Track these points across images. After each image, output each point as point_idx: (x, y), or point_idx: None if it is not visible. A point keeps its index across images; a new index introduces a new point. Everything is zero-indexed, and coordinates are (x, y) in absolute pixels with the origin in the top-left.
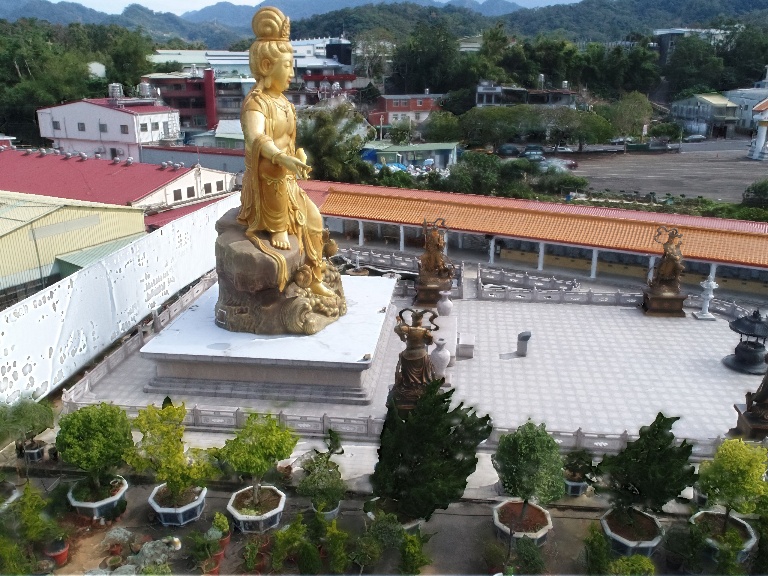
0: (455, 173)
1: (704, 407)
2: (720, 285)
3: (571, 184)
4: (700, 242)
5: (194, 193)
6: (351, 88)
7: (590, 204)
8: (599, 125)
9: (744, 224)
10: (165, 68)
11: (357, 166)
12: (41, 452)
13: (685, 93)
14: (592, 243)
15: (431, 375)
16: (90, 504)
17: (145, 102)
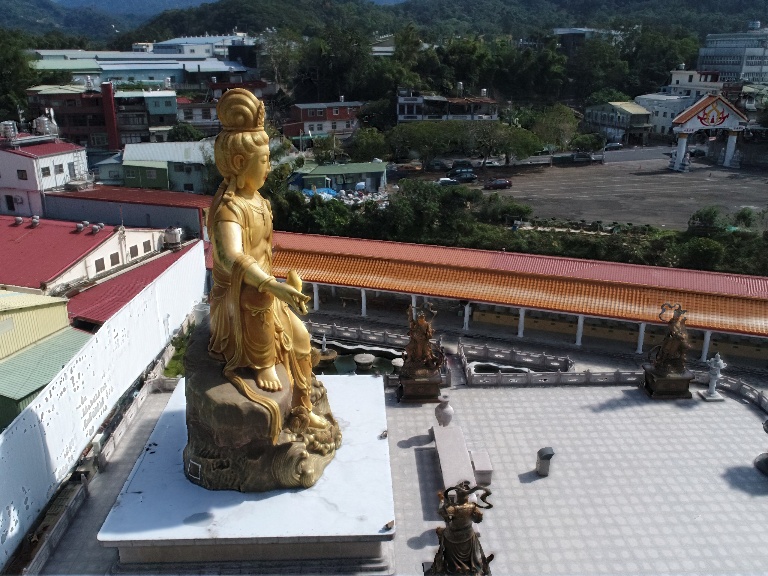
0: (395, 204)
1: (764, 541)
2: (711, 349)
3: (515, 212)
4: (692, 307)
5: (118, 259)
6: (261, 96)
7: (537, 234)
8: (528, 141)
9: (725, 278)
10: (53, 77)
11: (286, 195)
12: None
13: (595, 97)
14: (579, 310)
15: (481, 558)
16: None
17: (44, 140)
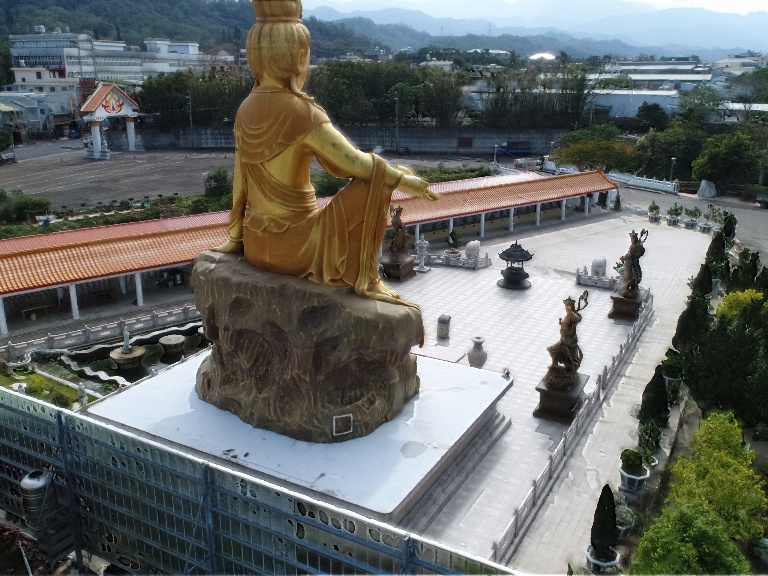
0: None
1: None
2: None
3: (34, 207)
4: None
5: None
6: None
7: (76, 224)
8: None
9: None
10: None
11: None
12: None
13: None
14: None
15: (579, 352)
16: None
17: None
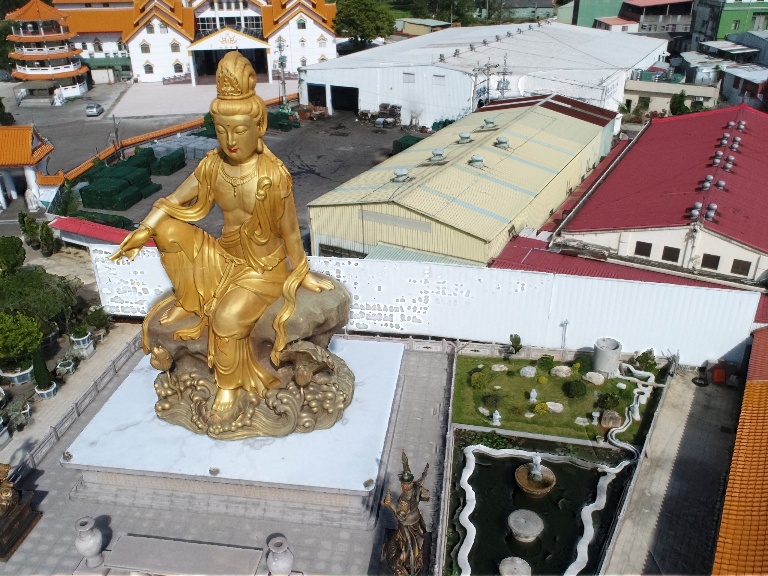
0: None
1: None
2: None
3: None
4: None
5: (678, 257)
6: None
7: None
8: None
9: None
10: None
11: None
12: None
13: None
14: None
15: None
16: None
17: None
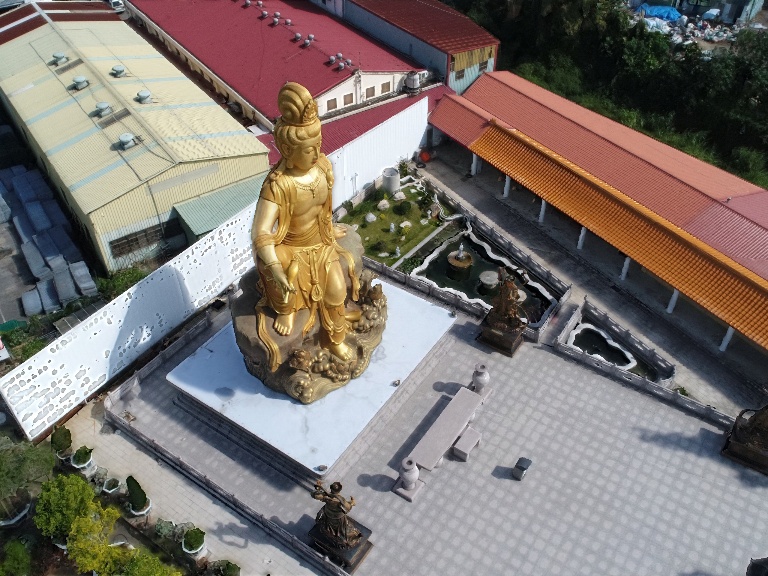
0: (713, 63)
1: None
2: None
3: None
4: None
5: (352, 99)
6: None
7: None
8: None
9: None
10: None
11: (608, 15)
12: (68, 459)
13: None
14: (726, 320)
15: (345, 533)
16: (59, 546)
17: None
